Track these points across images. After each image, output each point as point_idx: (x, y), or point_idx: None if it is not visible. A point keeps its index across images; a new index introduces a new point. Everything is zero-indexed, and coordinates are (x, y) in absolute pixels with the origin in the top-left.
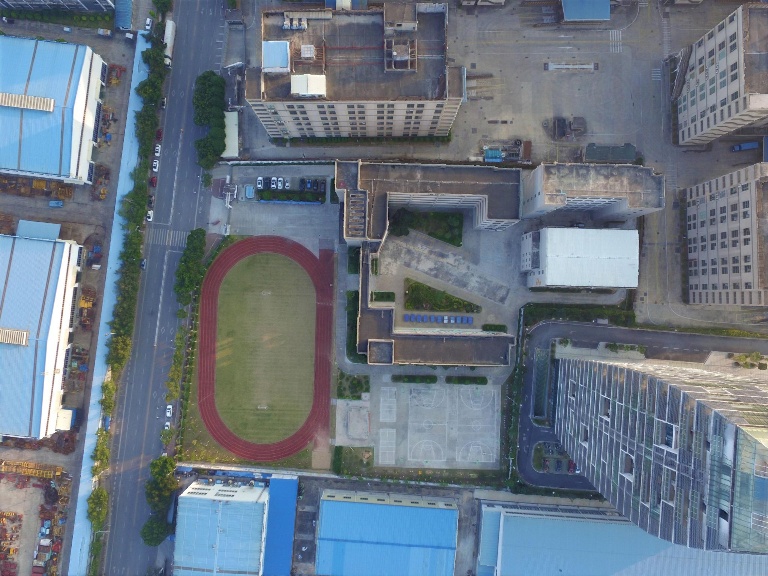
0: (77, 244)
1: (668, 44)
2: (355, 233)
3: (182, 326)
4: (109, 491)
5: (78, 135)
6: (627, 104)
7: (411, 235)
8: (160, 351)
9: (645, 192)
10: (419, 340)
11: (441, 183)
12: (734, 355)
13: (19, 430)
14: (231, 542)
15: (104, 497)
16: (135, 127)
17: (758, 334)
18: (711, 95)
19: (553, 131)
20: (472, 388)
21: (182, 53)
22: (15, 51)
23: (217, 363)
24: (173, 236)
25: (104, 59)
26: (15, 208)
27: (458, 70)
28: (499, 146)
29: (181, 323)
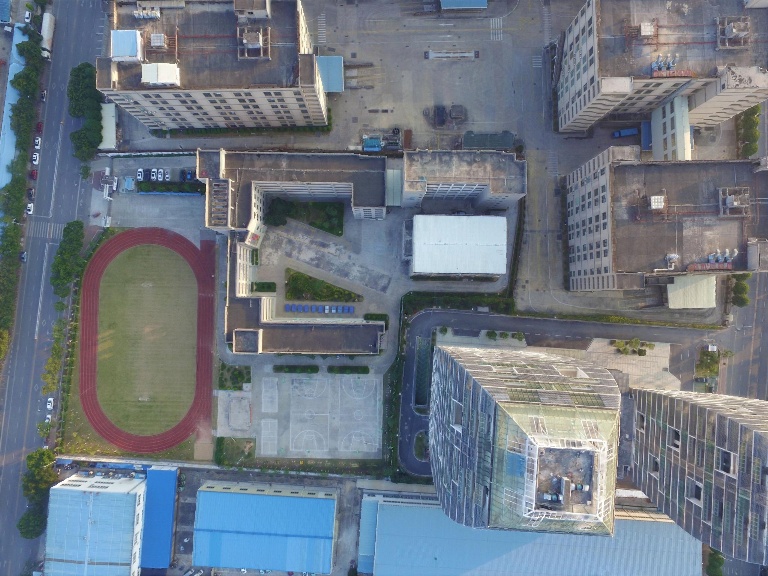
0: None
1: (549, 31)
2: (218, 222)
3: (63, 319)
4: None
5: None
6: (508, 92)
7: (292, 225)
8: (41, 344)
9: (508, 178)
10: (288, 329)
11: (307, 171)
12: (616, 342)
13: None
14: (102, 533)
15: None
16: (11, 120)
17: (638, 320)
18: (578, 80)
19: (434, 119)
20: (354, 377)
21: (62, 46)
22: None
23: (99, 355)
24: (54, 229)
25: None
26: None
27: (310, 57)
28: (380, 135)
29: (62, 316)
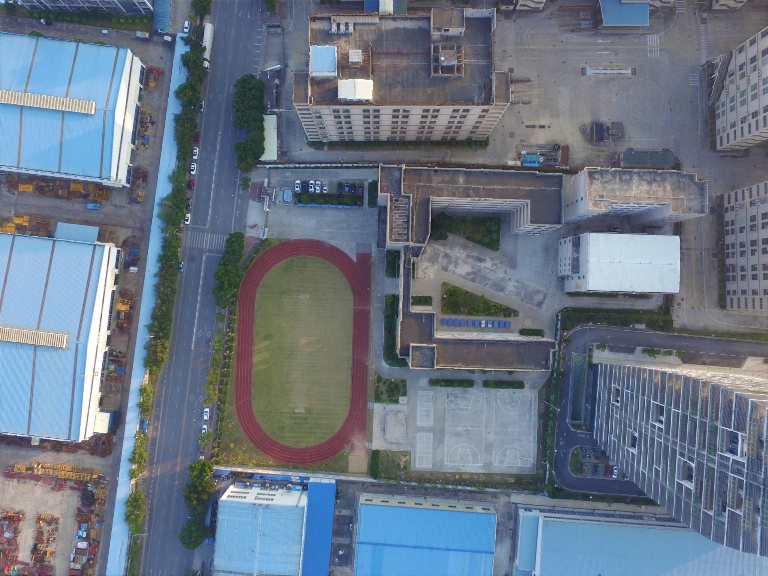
0: (115, 247)
1: (705, 49)
2: (398, 237)
3: (219, 329)
4: (146, 494)
5: (118, 138)
6: (664, 109)
7: (449, 239)
8: (197, 354)
9: (688, 198)
10: (460, 345)
11: (483, 188)
12: None
13: (58, 433)
14: (271, 546)
15: (142, 500)
16: (174, 130)
17: None
18: (753, 101)
19: (591, 136)
20: (509, 392)
21: (220, 56)
22: (56, 53)
23: (254, 366)
24: (210, 239)
25: (142, 61)
26: (52, 210)
27: (505, 75)
28: (537, 151)
29: (218, 326)
